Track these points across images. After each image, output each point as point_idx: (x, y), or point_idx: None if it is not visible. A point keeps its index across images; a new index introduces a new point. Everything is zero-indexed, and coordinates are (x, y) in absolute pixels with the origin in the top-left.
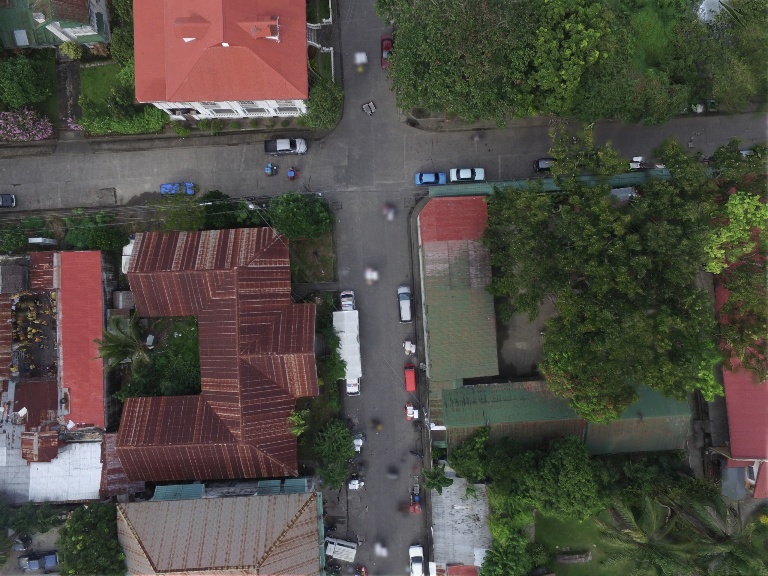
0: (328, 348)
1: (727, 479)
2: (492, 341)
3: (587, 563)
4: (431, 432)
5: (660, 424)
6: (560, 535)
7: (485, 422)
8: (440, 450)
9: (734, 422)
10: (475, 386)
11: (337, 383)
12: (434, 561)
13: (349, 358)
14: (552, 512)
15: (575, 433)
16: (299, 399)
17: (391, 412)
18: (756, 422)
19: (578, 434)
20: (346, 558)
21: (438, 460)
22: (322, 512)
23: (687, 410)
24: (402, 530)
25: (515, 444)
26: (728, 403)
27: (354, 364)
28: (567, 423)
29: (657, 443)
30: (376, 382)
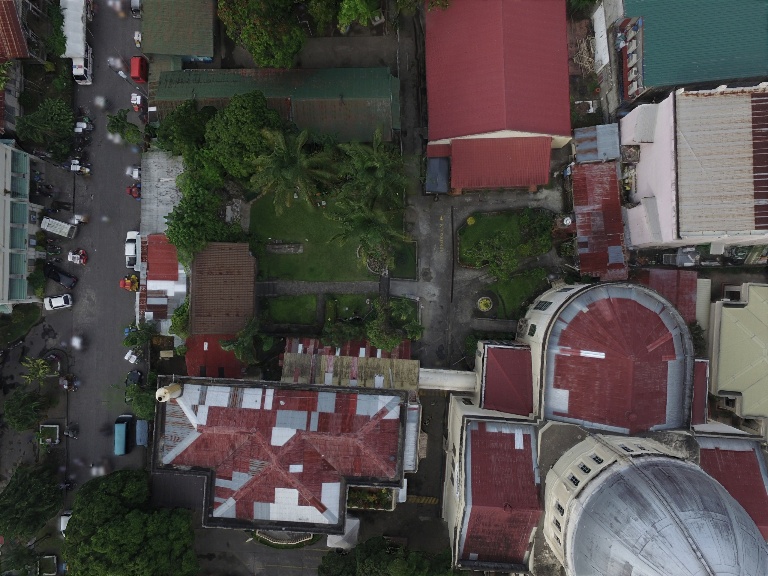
0: (53, 26)
1: (430, 172)
2: (208, 24)
3: (298, 255)
4: (149, 114)
5: (362, 108)
6: (274, 228)
7: (192, 96)
8: (154, 130)
9: (432, 107)
10: (193, 70)
11: (70, 73)
12: (139, 234)
13: (70, 34)
14: (217, 147)
15: (283, 116)
16: (33, 87)
17: (122, 105)
18: (449, 104)
19: (286, 118)
20: (60, 232)
21: (151, 138)
22: (27, 172)
23: (388, 94)
24: (125, 219)
25: (210, 108)
26: (428, 90)
27: (75, 41)
28: (272, 103)
29: (363, 132)
30: (109, 75)
